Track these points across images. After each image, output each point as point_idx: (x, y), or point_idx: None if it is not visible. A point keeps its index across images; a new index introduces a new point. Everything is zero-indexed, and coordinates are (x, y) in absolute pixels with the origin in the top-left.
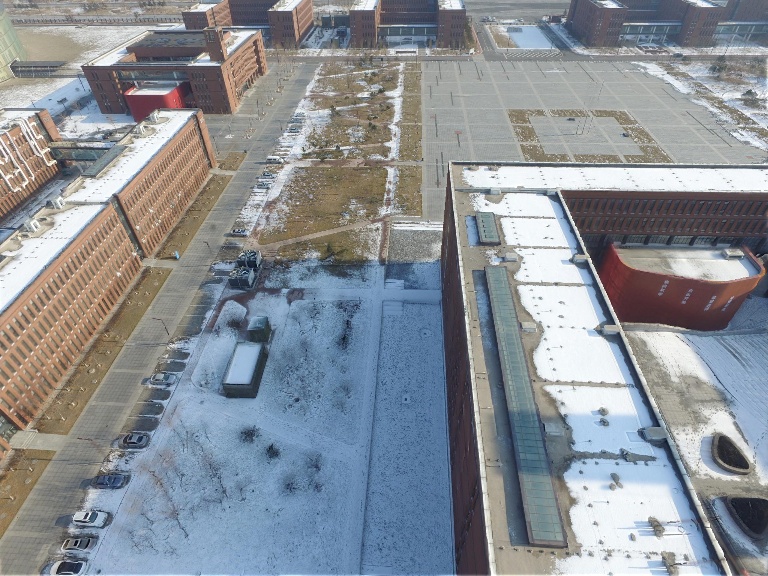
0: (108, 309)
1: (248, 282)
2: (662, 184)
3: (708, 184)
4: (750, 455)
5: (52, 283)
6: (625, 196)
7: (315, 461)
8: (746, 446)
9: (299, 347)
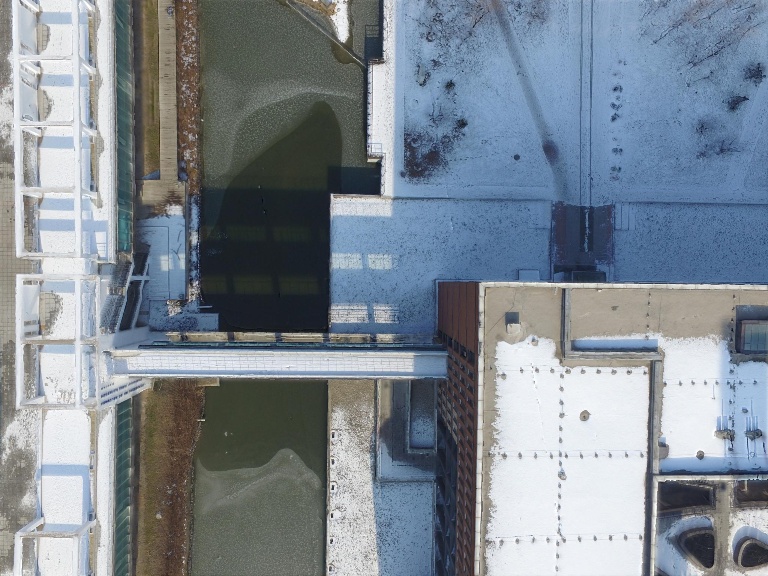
0: None
1: None
2: None
3: None
4: (753, 574)
5: None
6: None
7: (729, 148)
8: (763, 575)
9: None
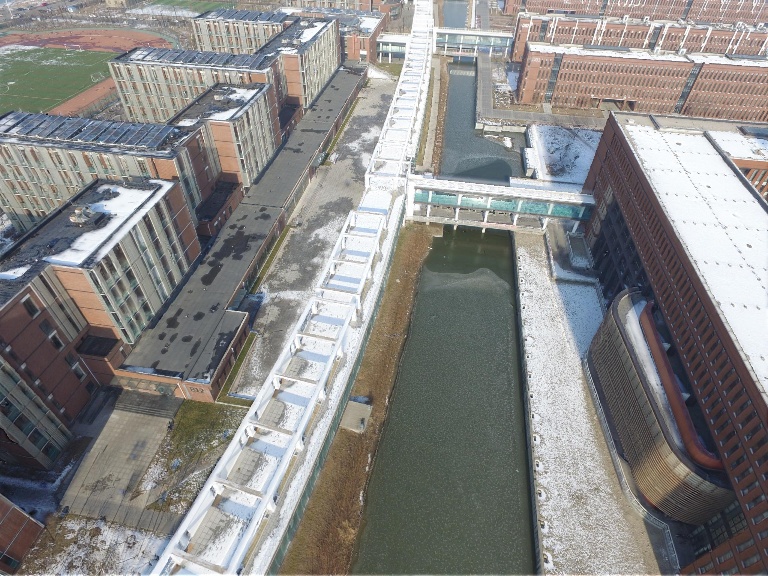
0: (763, 119)
1: None
2: None
3: None
4: None
5: (764, 76)
6: None
7: None
8: None
9: None
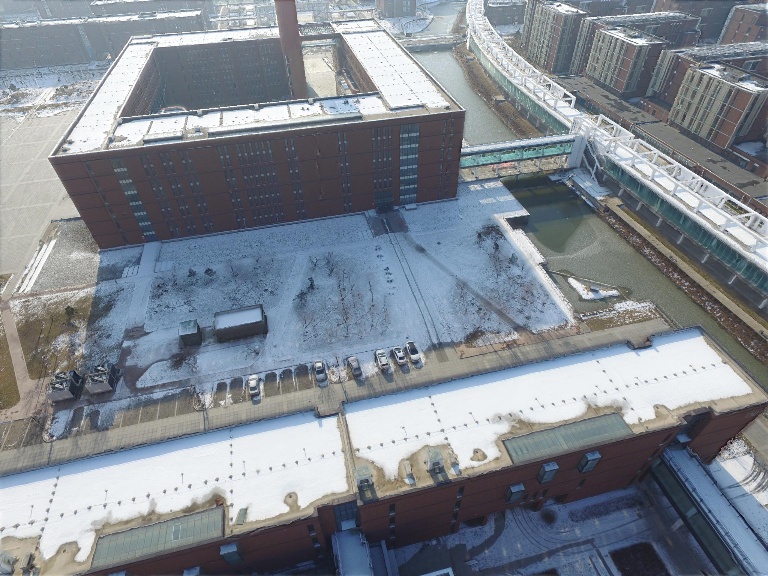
0: None
1: (114, 367)
2: (119, 95)
3: (123, 86)
4: None
5: None
6: (128, 106)
7: (313, 264)
8: None
9: (210, 306)
